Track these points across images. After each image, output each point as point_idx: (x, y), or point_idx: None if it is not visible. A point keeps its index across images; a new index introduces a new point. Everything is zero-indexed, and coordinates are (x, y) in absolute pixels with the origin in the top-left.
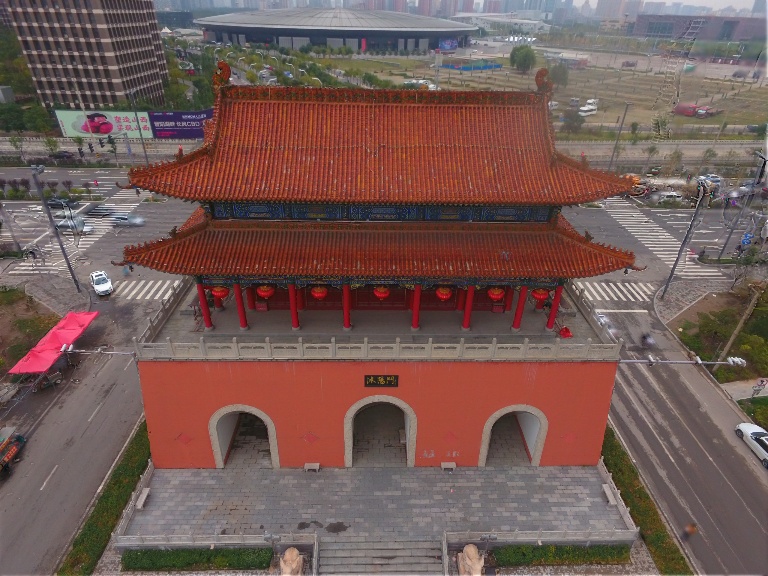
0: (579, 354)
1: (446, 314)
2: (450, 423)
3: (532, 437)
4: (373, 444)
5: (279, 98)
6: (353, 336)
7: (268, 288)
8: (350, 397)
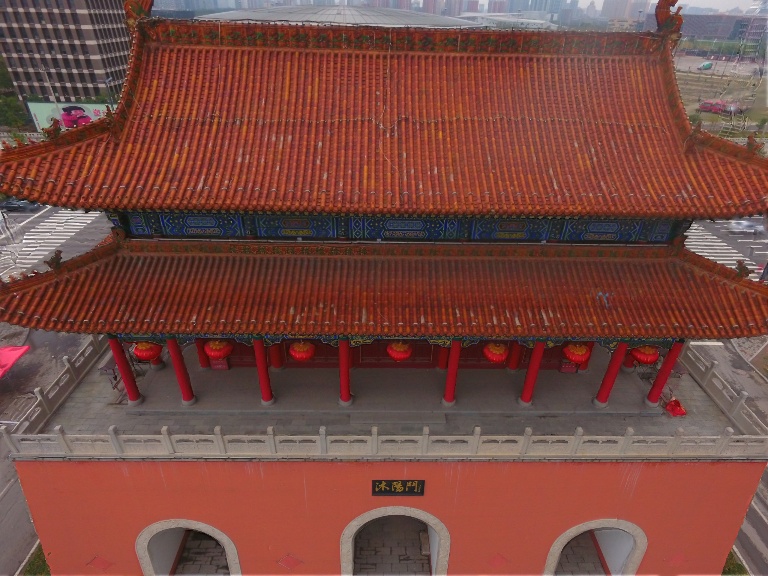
0: (709, 450)
1: (492, 375)
2: (500, 542)
3: (616, 554)
4: (383, 555)
5: (236, 42)
6: (354, 414)
7: (221, 344)
8: (349, 508)
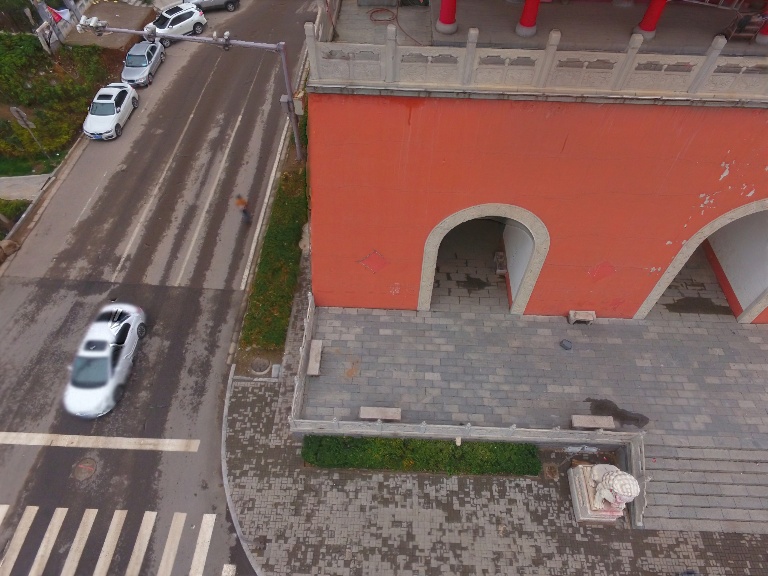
0: None
1: None
2: None
3: None
4: None
5: None
6: None
7: None
8: None
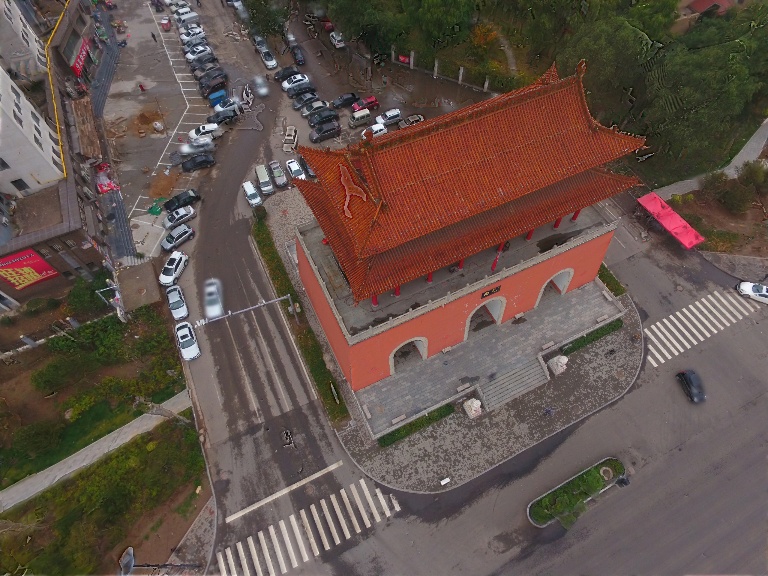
0: None
1: None
2: None
3: None
4: None
5: None
6: None
7: None
8: None
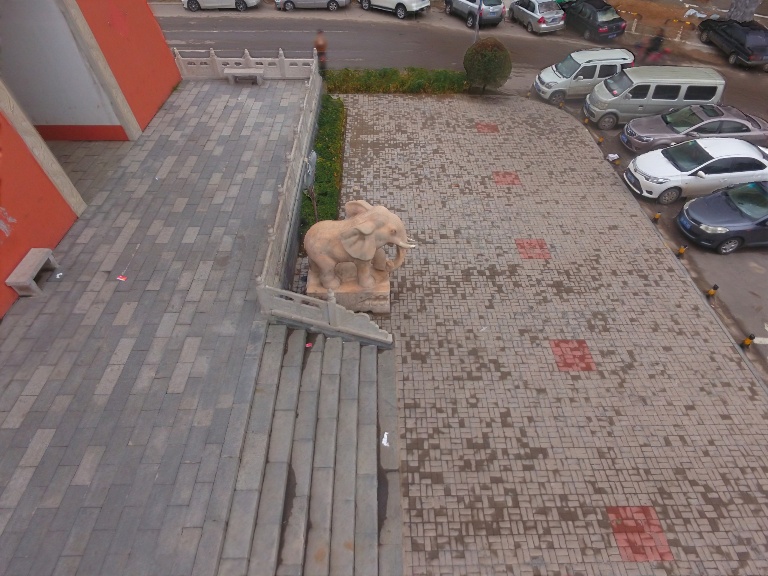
0: None
1: None
2: None
3: (71, 78)
4: None
5: None
6: None
7: None
8: None
